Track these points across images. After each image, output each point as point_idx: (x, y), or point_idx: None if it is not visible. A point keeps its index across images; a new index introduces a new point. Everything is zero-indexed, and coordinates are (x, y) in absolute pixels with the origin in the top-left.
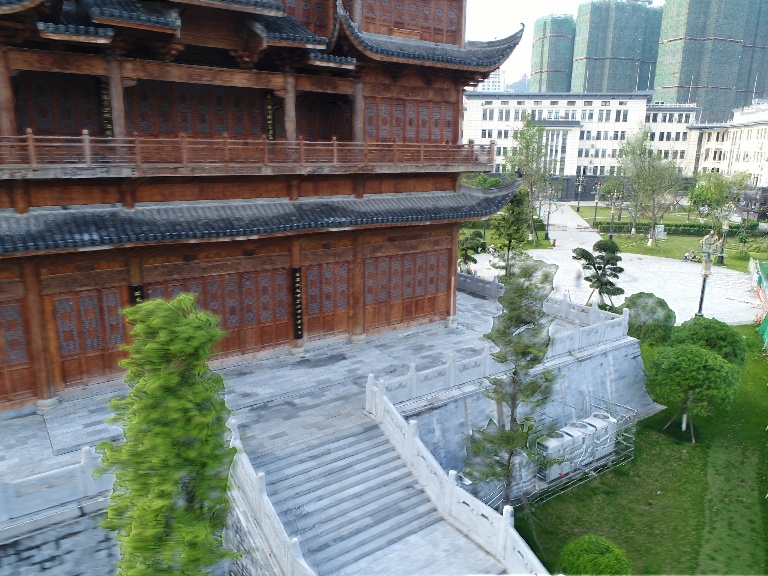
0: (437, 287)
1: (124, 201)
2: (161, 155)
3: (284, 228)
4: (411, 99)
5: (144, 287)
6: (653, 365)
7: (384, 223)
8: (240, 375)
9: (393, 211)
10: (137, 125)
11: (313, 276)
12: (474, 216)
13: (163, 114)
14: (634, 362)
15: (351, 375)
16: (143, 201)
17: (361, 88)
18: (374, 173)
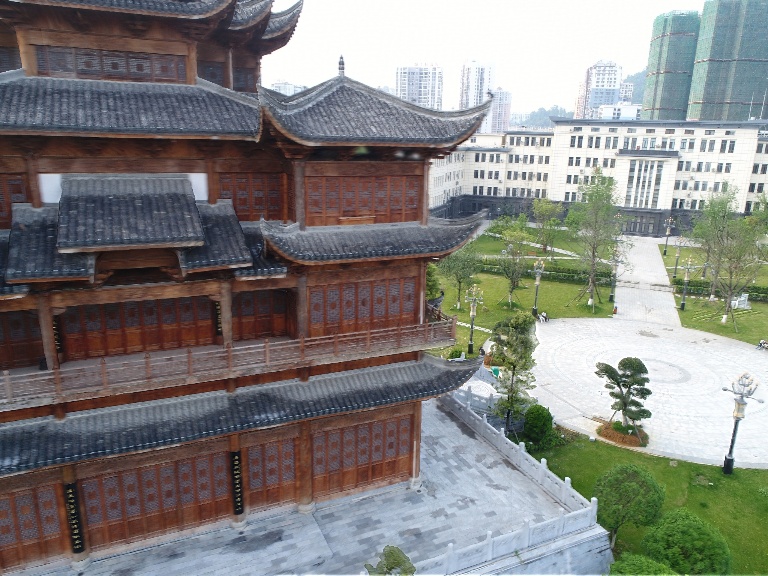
0: (398, 451)
1: (55, 413)
2: (82, 381)
3: (207, 434)
4: (363, 281)
5: (77, 483)
6: (610, 575)
7: (320, 415)
8: (171, 558)
9: (336, 396)
10: (84, 326)
11: (255, 455)
12: (428, 395)
13: (110, 313)
14: (600, 556)
15: (273, 570)
16: (75, 410)
17: (304, 281)
18: (312, 366)
